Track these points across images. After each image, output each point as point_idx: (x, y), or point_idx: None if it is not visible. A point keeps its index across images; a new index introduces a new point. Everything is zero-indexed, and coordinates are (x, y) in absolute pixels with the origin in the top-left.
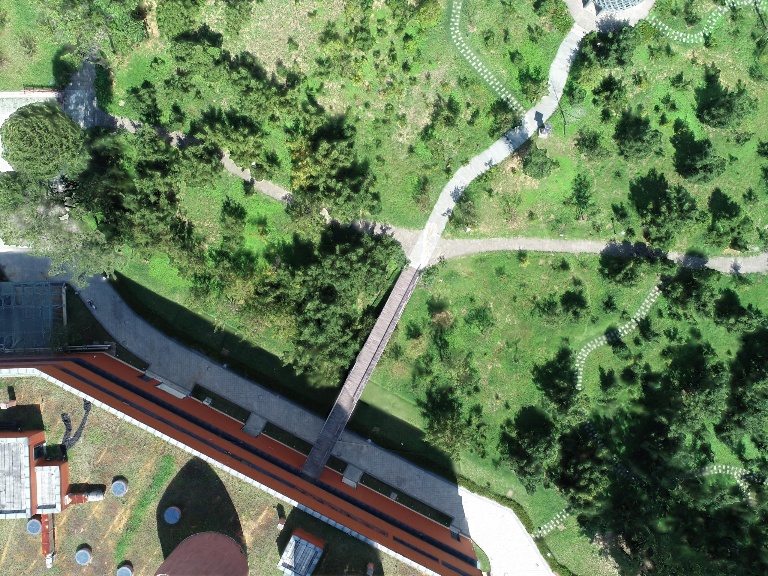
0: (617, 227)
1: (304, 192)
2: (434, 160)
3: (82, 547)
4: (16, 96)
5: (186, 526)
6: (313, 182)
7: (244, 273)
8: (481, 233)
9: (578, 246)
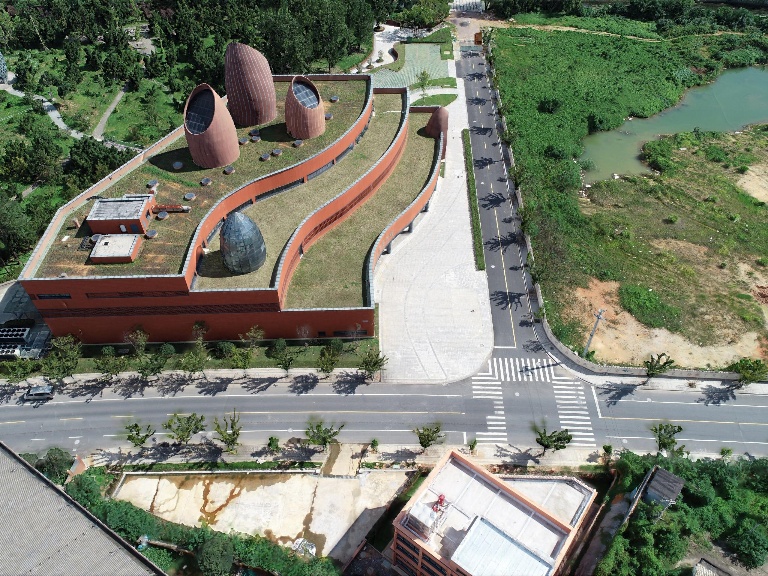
0: (114, 87)
1: None
2: None
3: None
4: None
5: (187, 163)
6: None
7: None
8: (95, 123)
9: (118, 98)
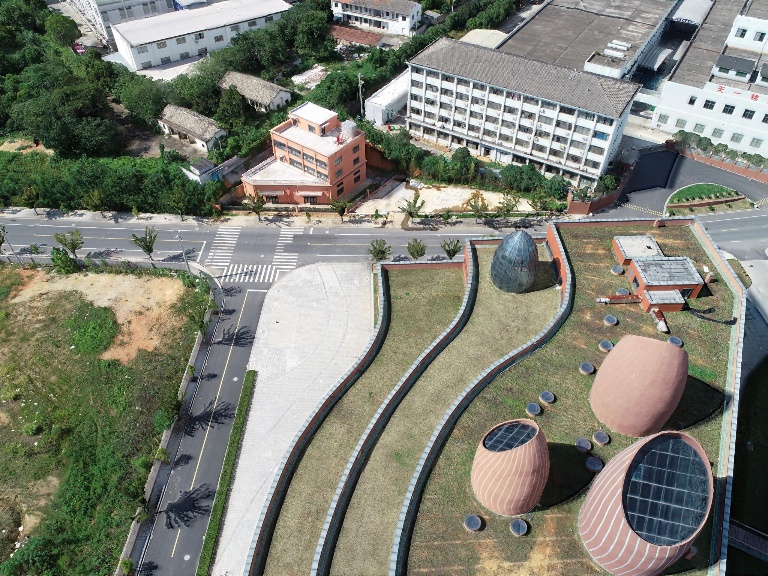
0: None
1: None
2: None
3: None
4: None
5: None
6: None
7: None
8: None
9: None
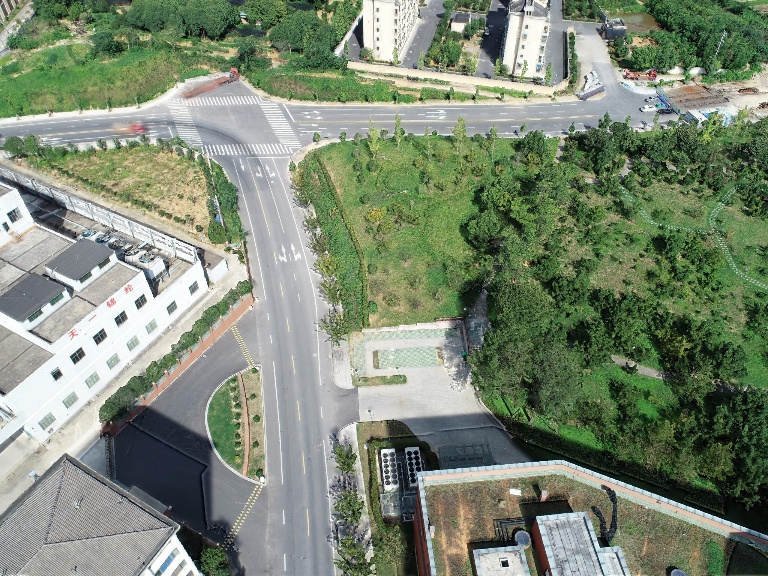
0: None
1: (687, 359)
2: (766, 341)
3: None
4: (425, 327)
5: None
6: (688, 354)
7: (646, 435)
8: None
9: None
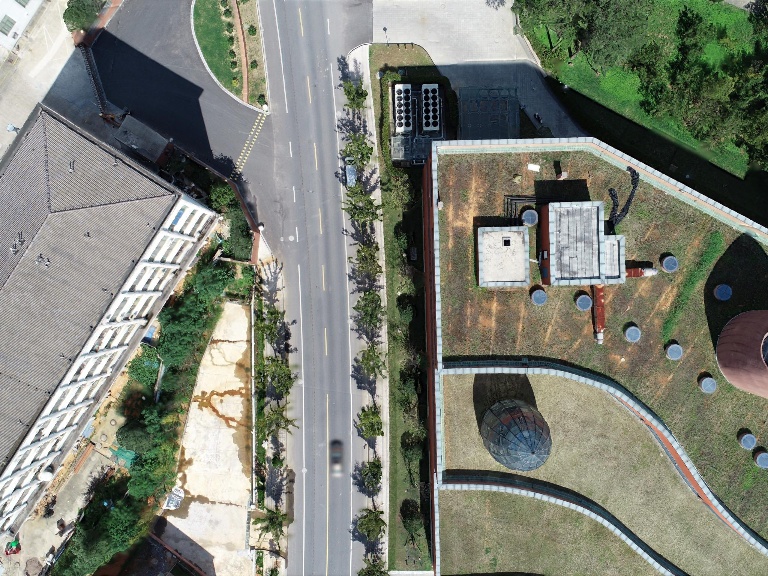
0: None
1: None
2: None
3: (629, 325)
4: None
5: (734, 305)
6: None
7: (699, 85)
8: None
9: None
